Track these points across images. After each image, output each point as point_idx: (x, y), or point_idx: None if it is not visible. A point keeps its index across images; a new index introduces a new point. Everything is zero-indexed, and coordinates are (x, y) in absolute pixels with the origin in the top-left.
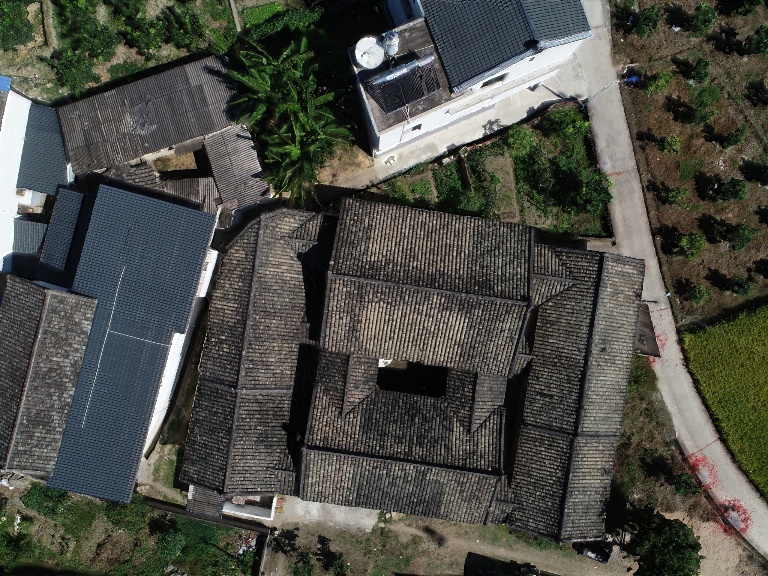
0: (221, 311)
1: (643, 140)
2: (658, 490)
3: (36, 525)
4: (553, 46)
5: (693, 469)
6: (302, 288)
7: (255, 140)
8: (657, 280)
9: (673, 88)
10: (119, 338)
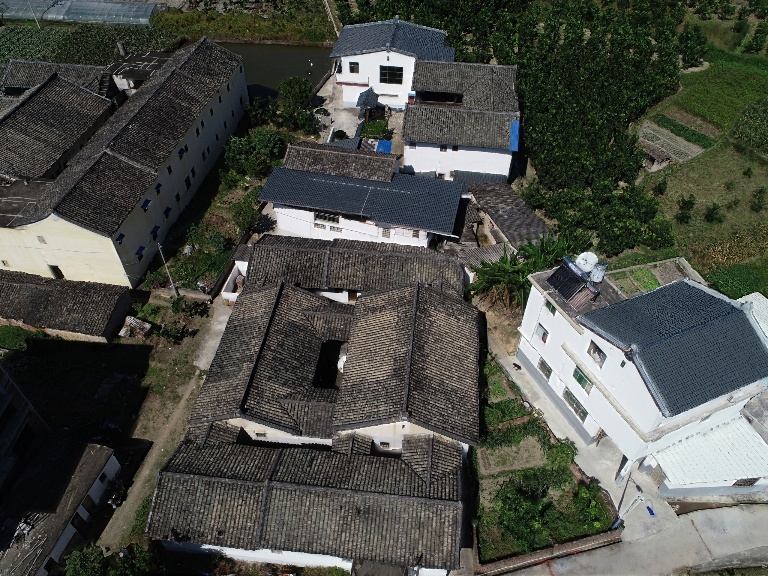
0: (385, 246)
1: None
2: None
3: (241, 192)
4: (639, 370)
5: None
6: None
7: None
8: None
9: None
10: (366, 192)
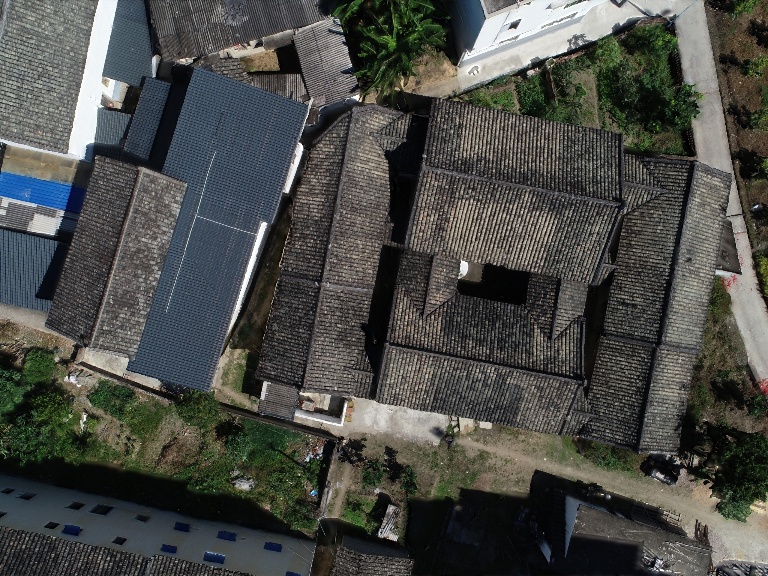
0: (306, 206)
1: (726, 63)
2: (728, 414)
3: (102, 424)
4: None
5: (763, 395)
6: (387, 187)
7: (347, 35)
8: (735, 203)
9: (758, 12)
10: (207, 224)
